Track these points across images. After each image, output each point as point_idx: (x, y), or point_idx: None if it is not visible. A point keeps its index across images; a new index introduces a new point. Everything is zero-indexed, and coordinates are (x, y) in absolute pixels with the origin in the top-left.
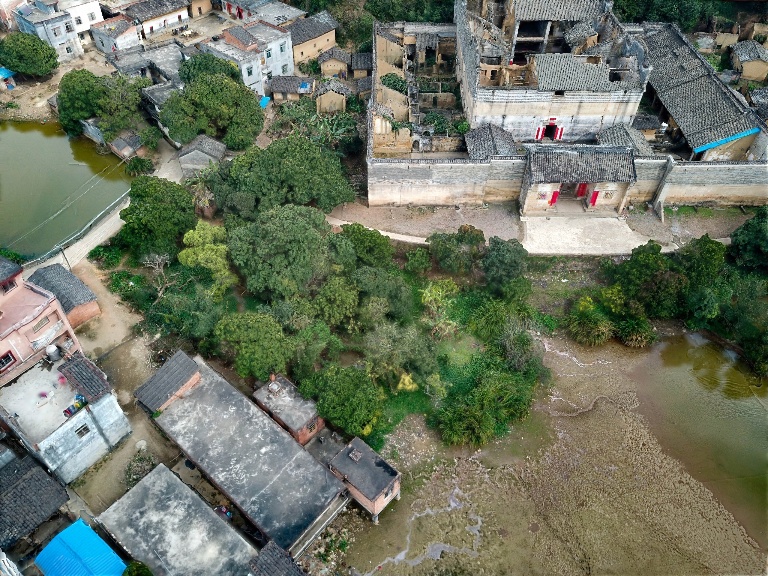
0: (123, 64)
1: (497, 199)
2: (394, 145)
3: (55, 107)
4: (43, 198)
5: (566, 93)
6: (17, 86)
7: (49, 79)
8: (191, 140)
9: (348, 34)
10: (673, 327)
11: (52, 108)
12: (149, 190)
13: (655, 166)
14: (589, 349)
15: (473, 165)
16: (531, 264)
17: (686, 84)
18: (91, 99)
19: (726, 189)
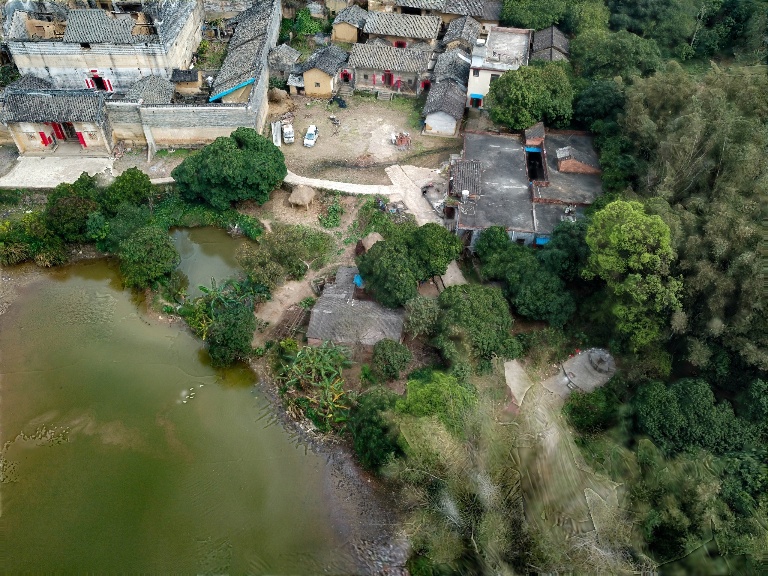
0: None
1: (9, 141)
2: None
3: None
4: None
5: (91, 45)
6: None
7: None
8: None
9: None
10: (98, 251)
11: None
12: None
13: (132, 109)
14: (3, 268)
15: None
16: (1, 197)
17: (248, 42)
18: None
19: (207, 132)
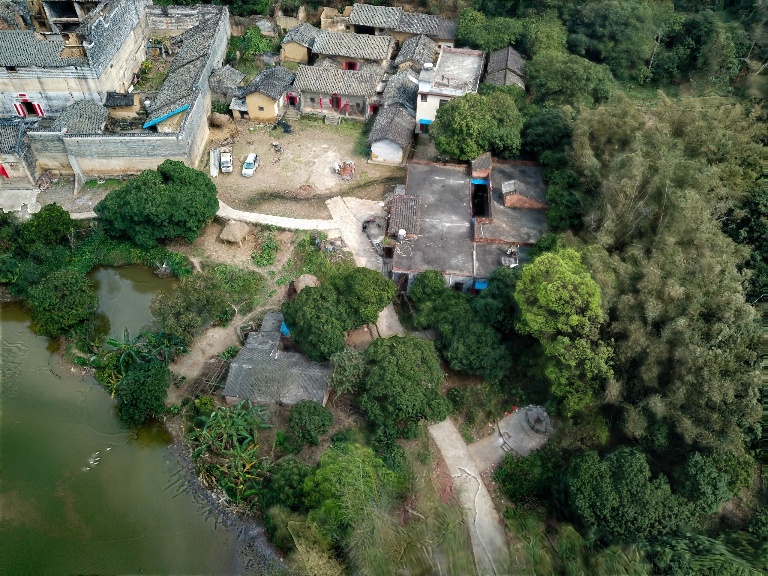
0: None
1: None
2: None
3: None
4: None
5: (18, 69)
6: None
7: None
8: None
9: None
10: None
11: None
12: None
13: (56, 139)
14: None
15: None
16: None
17: (190, 63)
18: None
19: (138, 162)
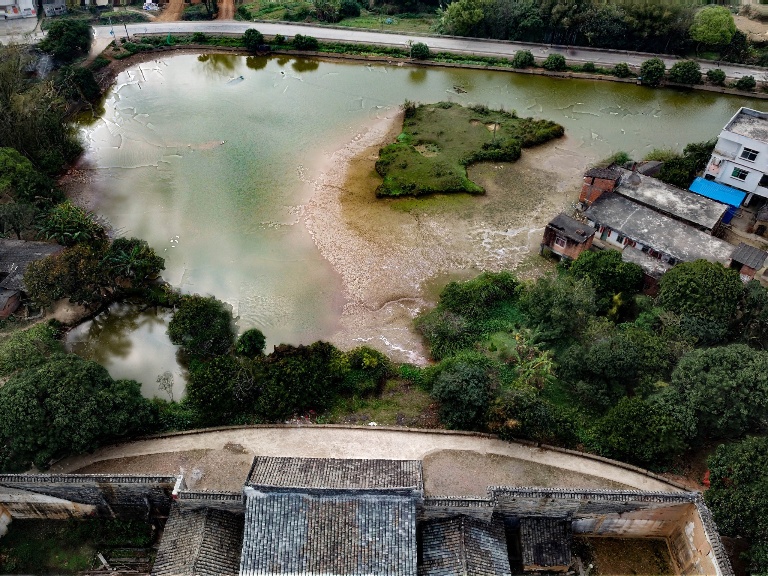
0: None
1: None
2: None
3: None
4: None
5: None
6: None
7: None
8: None
9: None
10: None
11: None
12: None
13: None
14: None
15: None
16: None
17: None
18: None
19: None
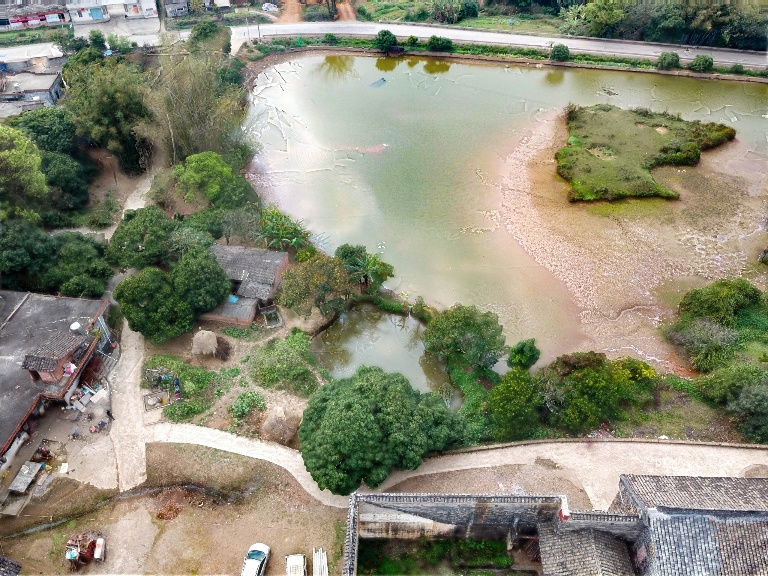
0: None
1: None
2: None
3: None
4: None
5: None
6: None
7: None
8: None
9: None
10: None
11: None
12: None
13: None
14: None
15: None
16: None
17: None
18: None
19: None
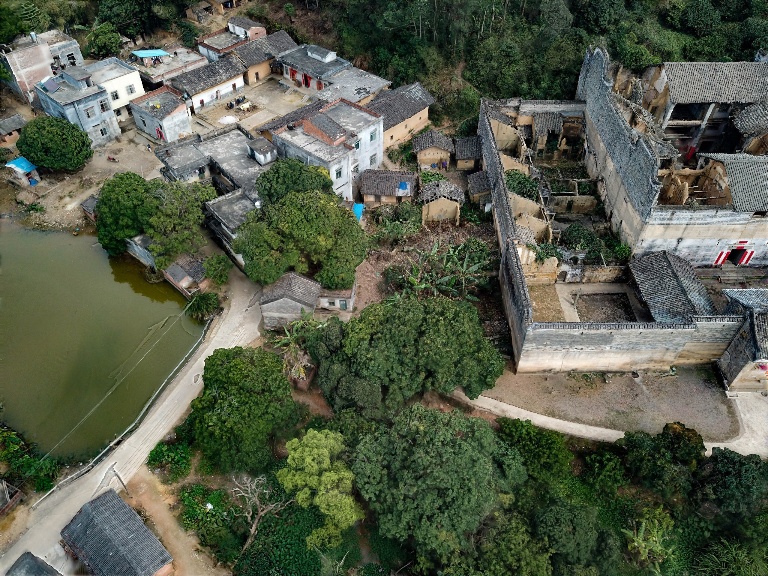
0: (176, 161)
1: (688, 362)
2: (534, 276)
3: (90, 214)
4: (81, 356)
5: None
6: (42, 180)
7: (80, 170)
8: (275, 280)
9: (444, 110)
10: None
11: (86, 213)
12: (233, 375)
13: None
14: None
15: (671, 330)
16: None
17: None
18: (140, 215)
19: None
